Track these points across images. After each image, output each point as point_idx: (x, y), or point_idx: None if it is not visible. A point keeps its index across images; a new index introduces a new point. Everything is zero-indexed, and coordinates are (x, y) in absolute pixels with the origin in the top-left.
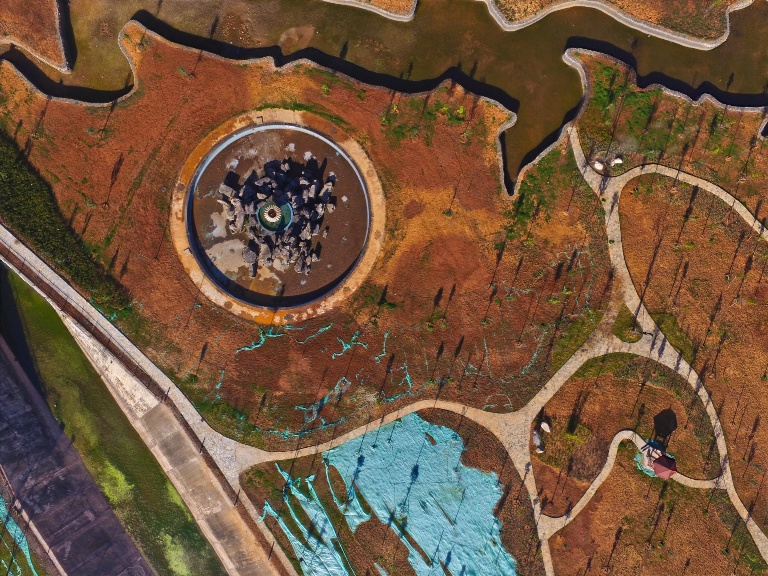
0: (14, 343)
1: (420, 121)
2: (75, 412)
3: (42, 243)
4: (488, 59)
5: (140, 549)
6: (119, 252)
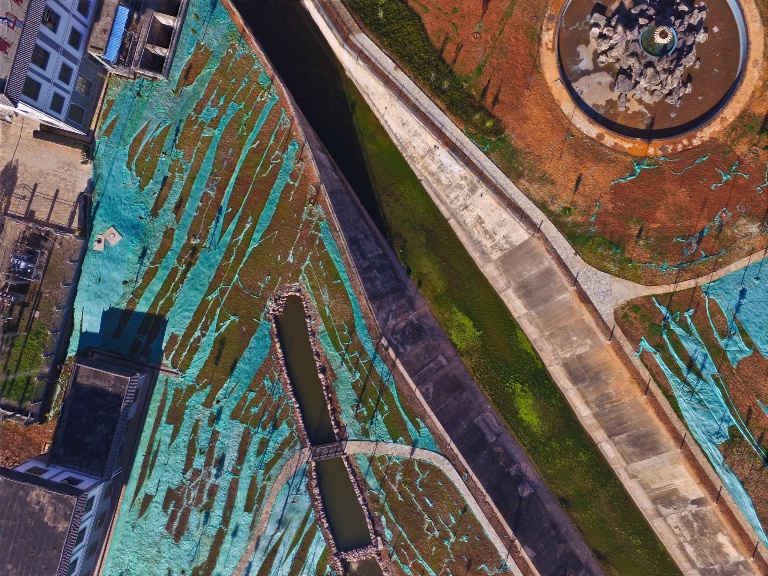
0: (358, 187)
1: None
2: (421, 257)
3: (419, 70)
4: None
5: (489, 397)
6: (491, 82)
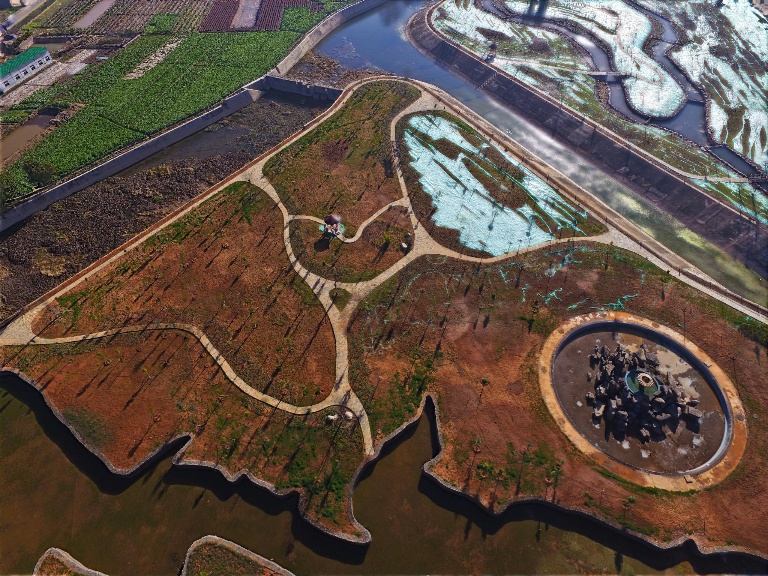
0: None
1: (522, 468)
2: (743, 276)
3: None
4: (453, 542)
5: (658, 209)
6: None
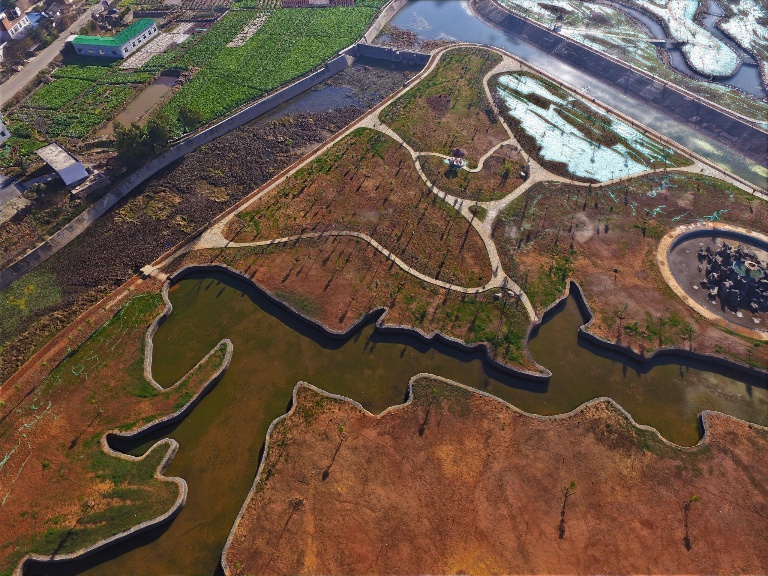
0: None
1: (661, 328)
2: None
3: None
4: (615, 379)
5: (730, 150)
6: None
